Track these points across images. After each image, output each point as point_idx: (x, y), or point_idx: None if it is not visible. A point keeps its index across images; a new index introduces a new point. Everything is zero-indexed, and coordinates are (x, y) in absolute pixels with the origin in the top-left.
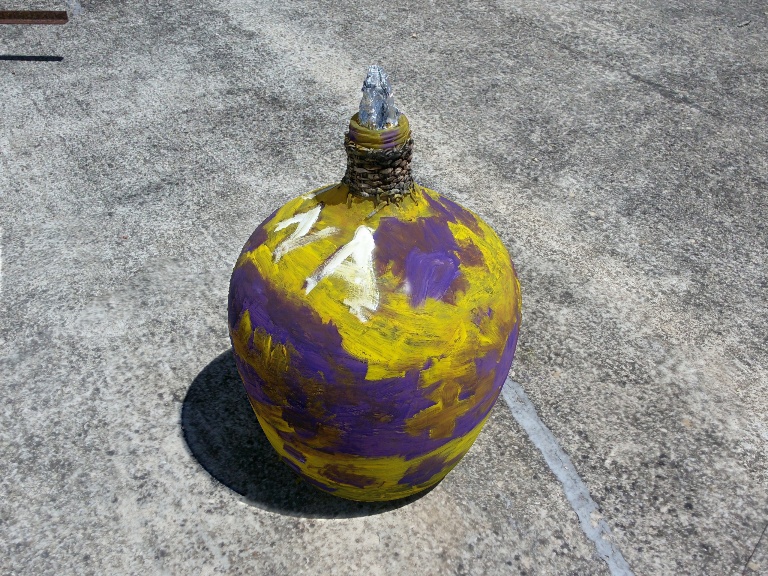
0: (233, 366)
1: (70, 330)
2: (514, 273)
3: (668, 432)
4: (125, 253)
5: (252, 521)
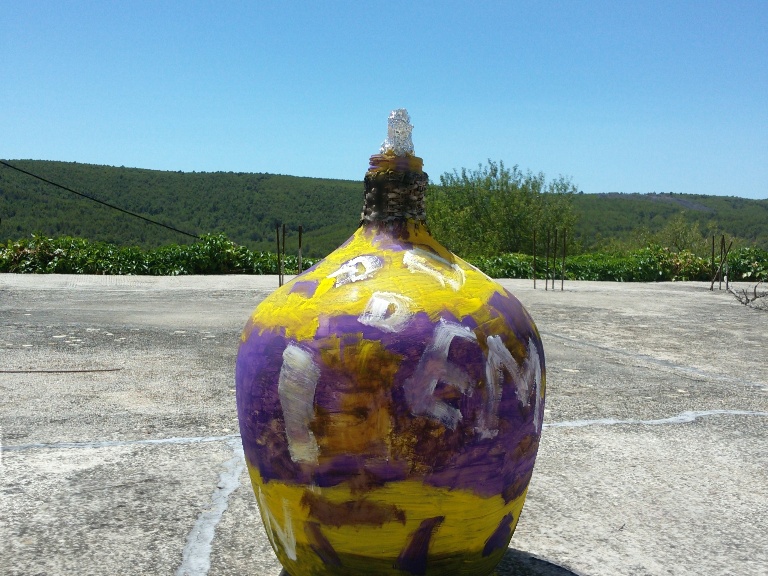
0: None
1: None
2: None
3: (60, 539)
4: None
5: (522, 543)
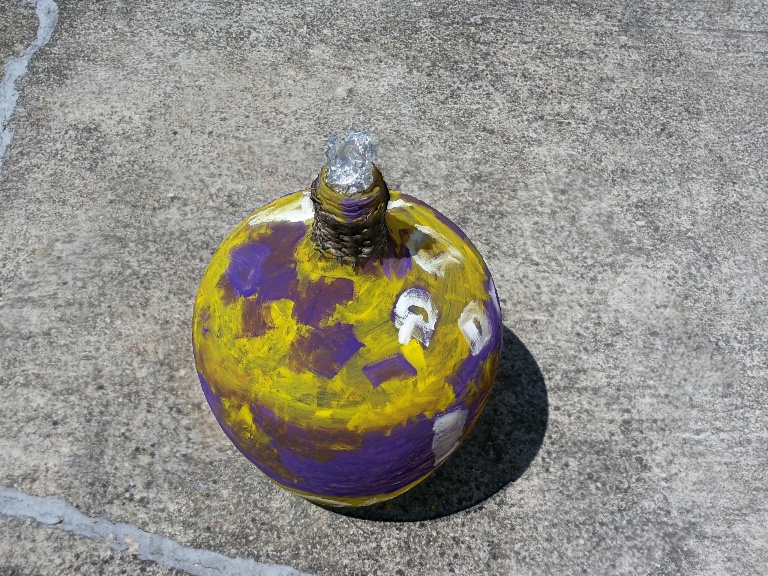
0: (513, 365)
1: (634, 268)
2: (253, 406)
3: None
4: (760, 346)
5: None
